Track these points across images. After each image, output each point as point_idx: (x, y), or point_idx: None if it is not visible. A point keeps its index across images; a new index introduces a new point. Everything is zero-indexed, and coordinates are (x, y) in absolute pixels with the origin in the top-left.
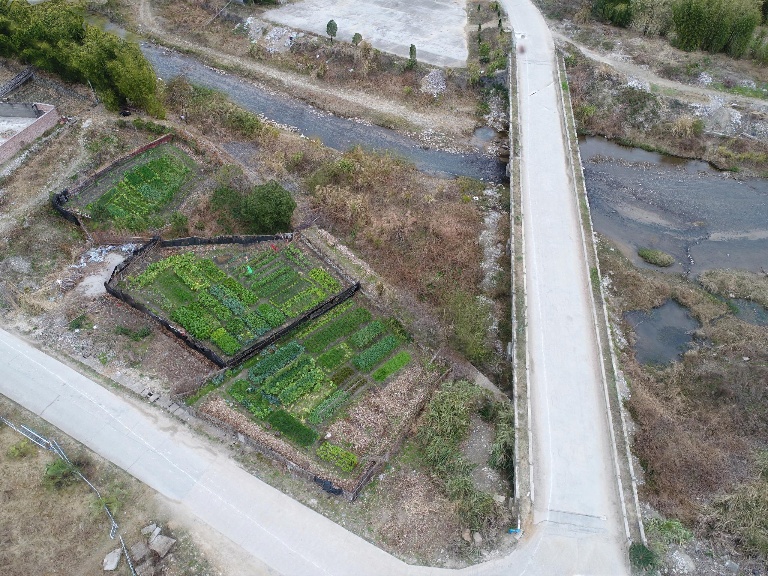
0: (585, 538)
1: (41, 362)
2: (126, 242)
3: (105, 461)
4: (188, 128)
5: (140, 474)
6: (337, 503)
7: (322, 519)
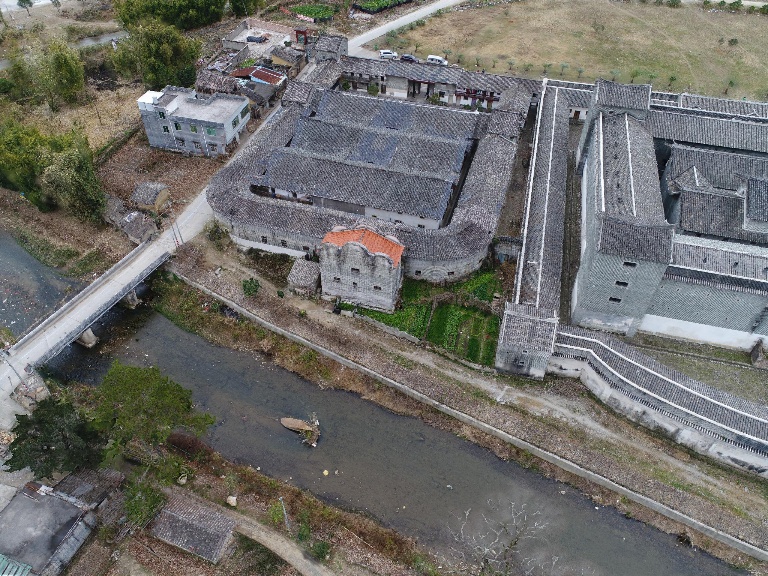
0: None
1: None
2: (350, 12)
3: None
4: (279, 2)
5: None
6: None
7: None
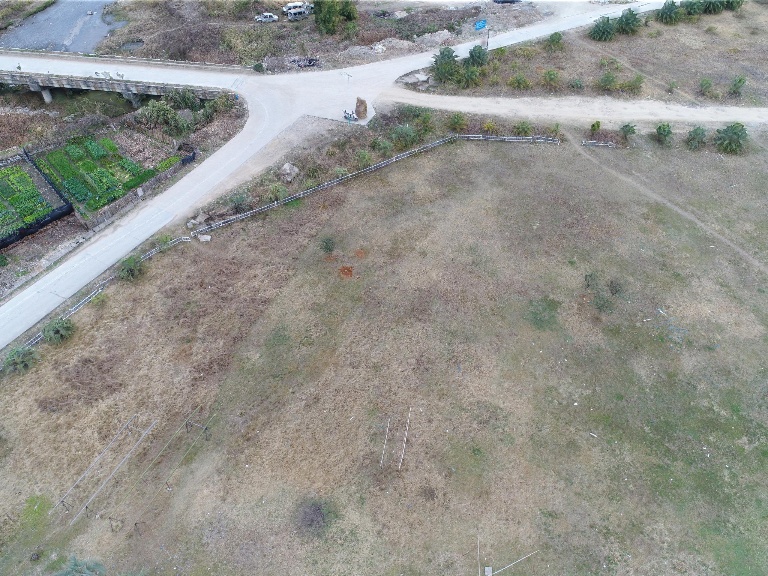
0: (246, 82)
1: (0, 314)
2: None
3: (129, 254)
4: None
5: (148, 235)
6: (200, 158)
7: (208, 159)
